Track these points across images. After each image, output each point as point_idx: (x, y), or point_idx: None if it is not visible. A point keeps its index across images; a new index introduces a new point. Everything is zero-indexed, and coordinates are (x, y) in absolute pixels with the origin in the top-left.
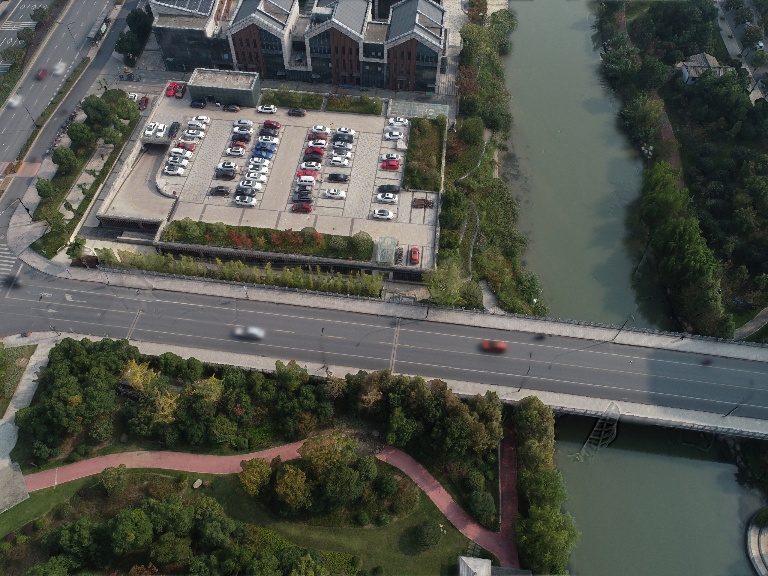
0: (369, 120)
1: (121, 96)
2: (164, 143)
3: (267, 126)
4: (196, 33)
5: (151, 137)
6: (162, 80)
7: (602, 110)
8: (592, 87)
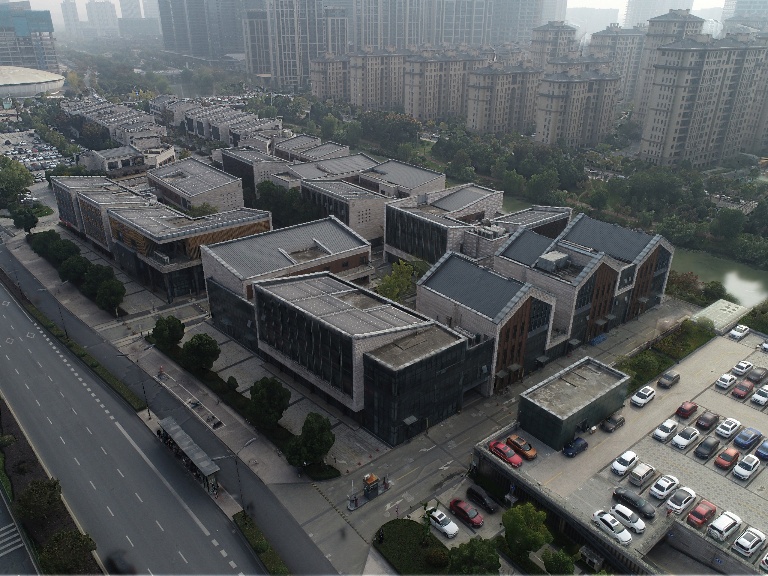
0: (720, 346)
1: (416, 529)
2: (663, 534)
3: (690, 413)
4: (455, 350)
5: (634, 541)
6: (414, 464)
7: (729, 264)
8: (689, 255)
